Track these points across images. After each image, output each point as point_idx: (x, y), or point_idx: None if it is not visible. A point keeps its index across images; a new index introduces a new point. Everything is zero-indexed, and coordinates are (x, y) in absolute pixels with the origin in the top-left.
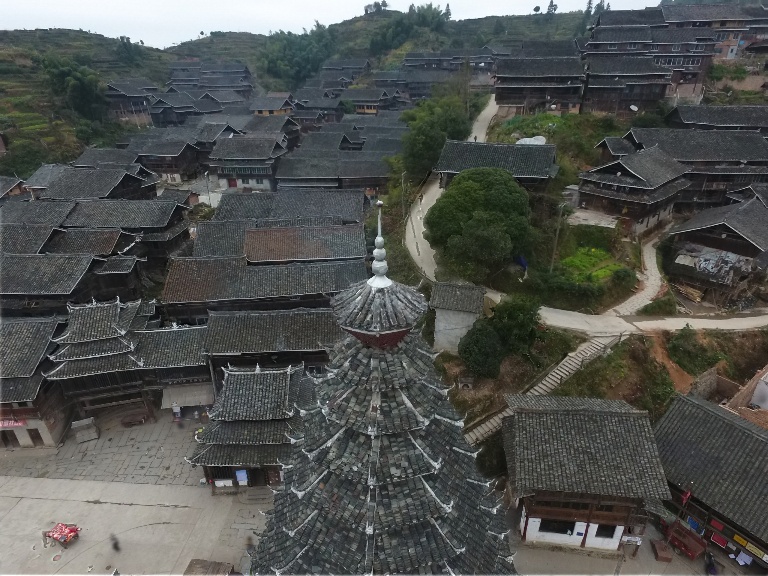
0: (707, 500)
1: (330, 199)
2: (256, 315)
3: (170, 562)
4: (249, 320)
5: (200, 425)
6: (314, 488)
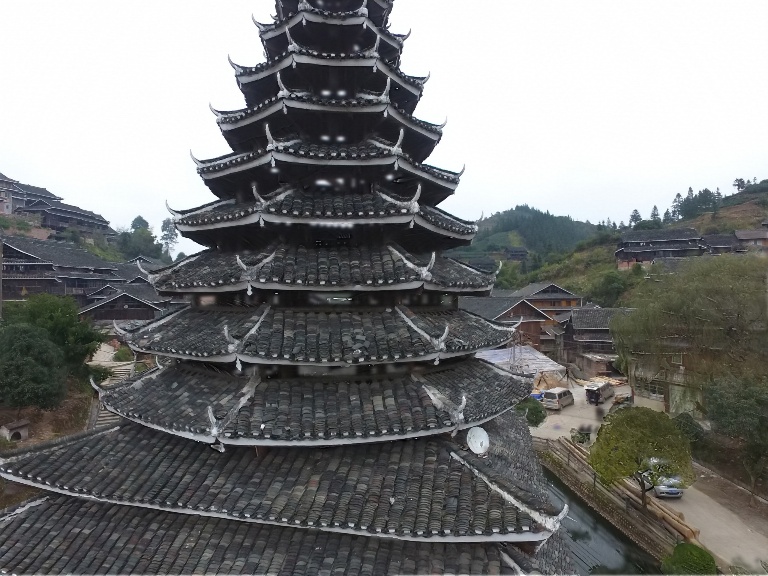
0: None
1: None
2: None
3: None
4: None
5: None
6: None
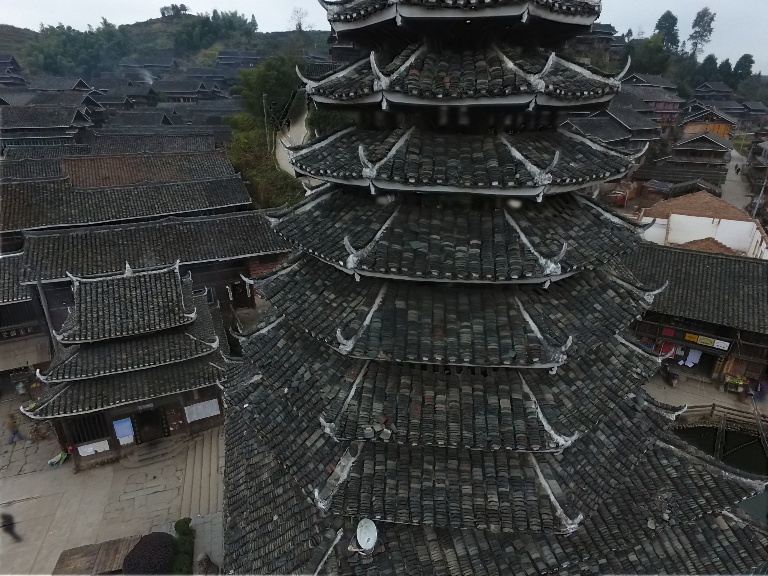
0: (658, 308)
1: (171, 143)
2: (104, 231)
3: (18, 574)
4: (94, 238)
5: (30, 403)
6: (403, 75)
